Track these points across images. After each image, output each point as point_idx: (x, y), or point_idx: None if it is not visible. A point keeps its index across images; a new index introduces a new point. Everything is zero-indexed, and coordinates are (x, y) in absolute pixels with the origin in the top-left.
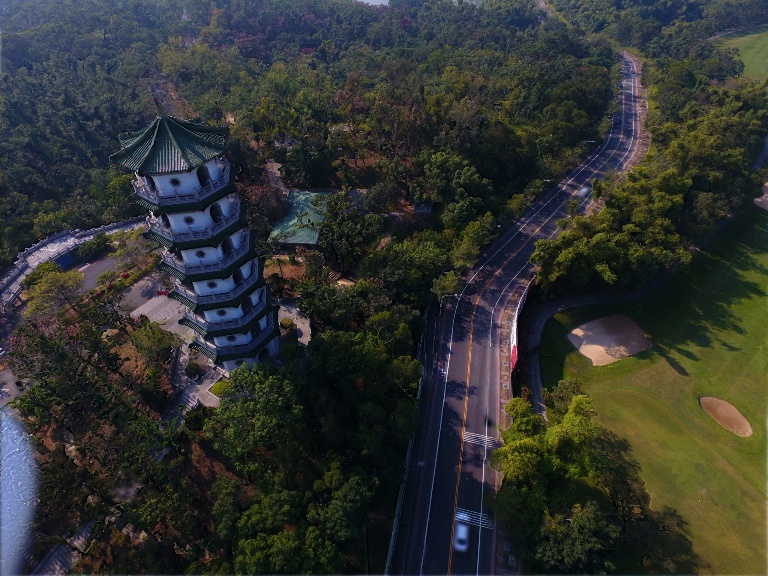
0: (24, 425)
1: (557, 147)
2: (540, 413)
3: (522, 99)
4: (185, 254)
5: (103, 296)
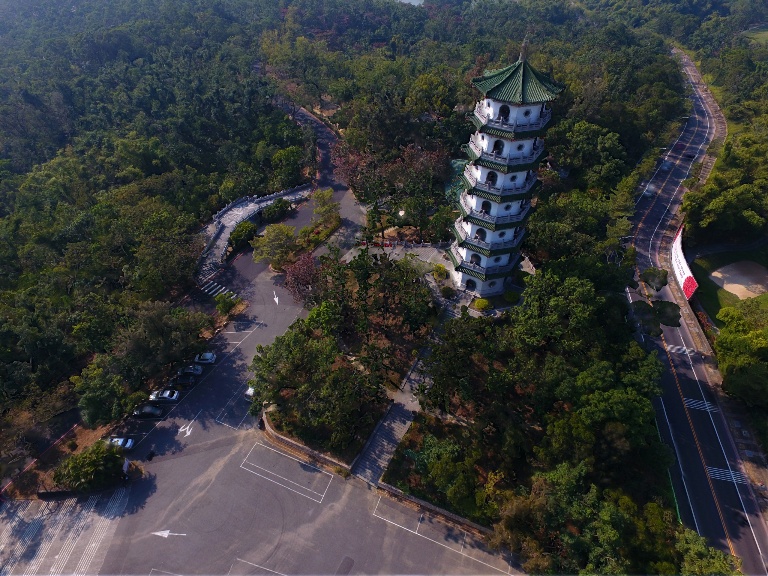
0: None
1: (660, 122)
2: (716, 333)
3: (614, 82)
4: (503, 178)
5: (307, 248)
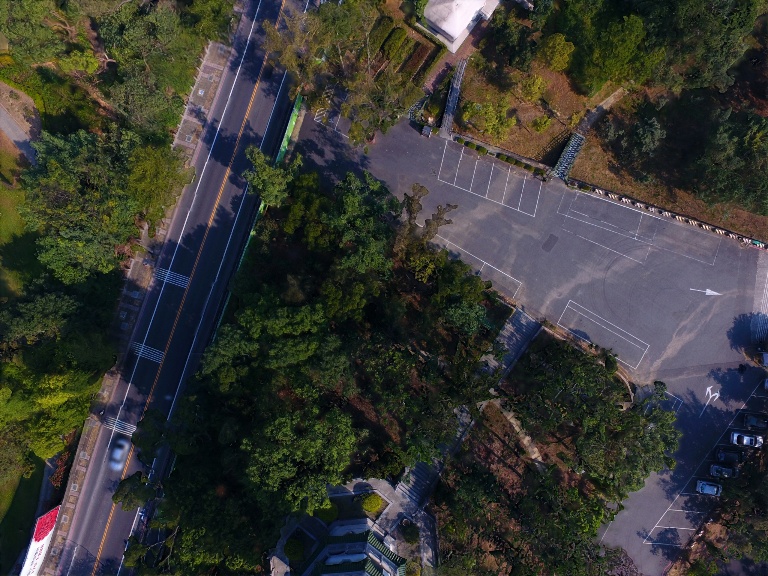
0: (596, 488)
1: None
2: None
3: None
4: None
5: None
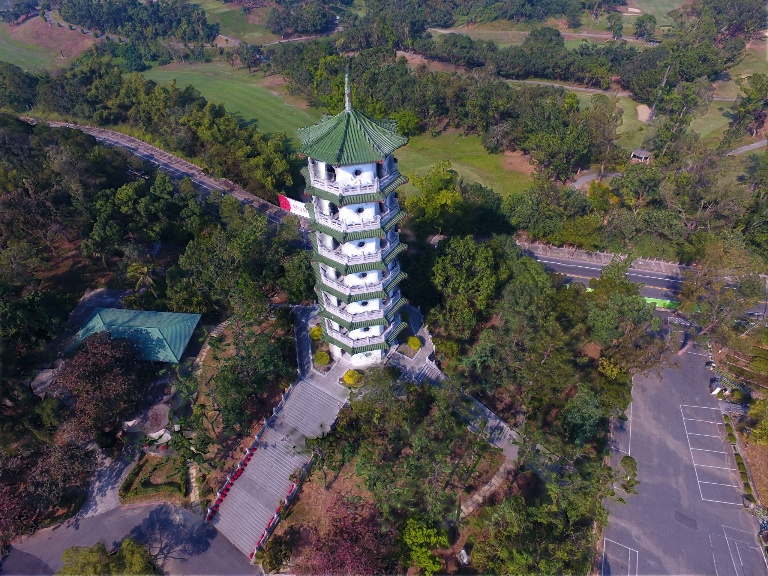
0: None
1: None
2: None
3: None
4: None
5: None
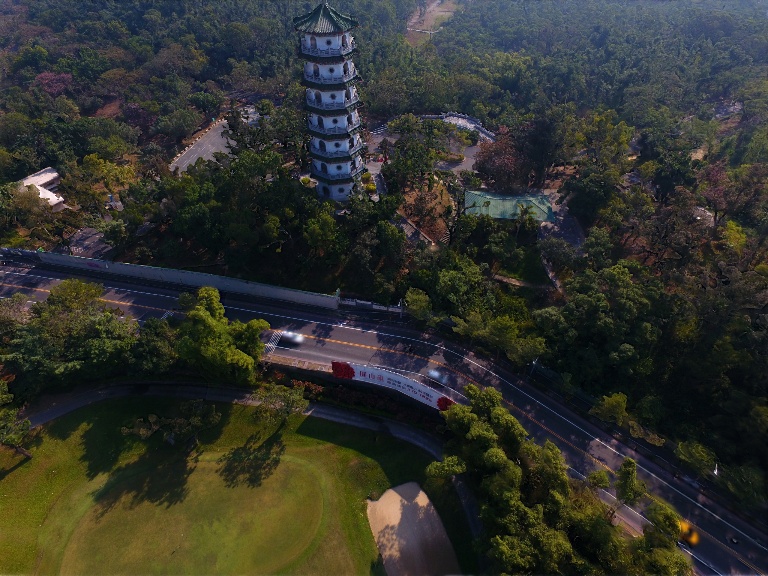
0: None
1: None
2: None
3: None
4: None
5: None
